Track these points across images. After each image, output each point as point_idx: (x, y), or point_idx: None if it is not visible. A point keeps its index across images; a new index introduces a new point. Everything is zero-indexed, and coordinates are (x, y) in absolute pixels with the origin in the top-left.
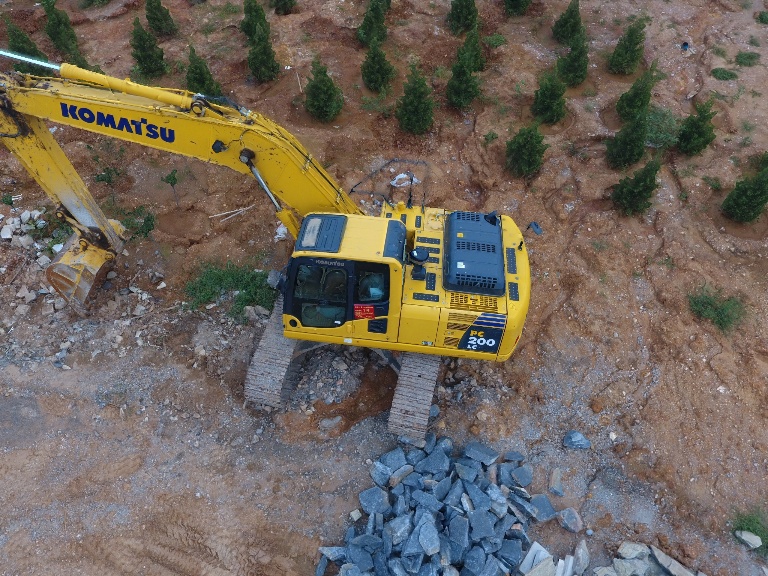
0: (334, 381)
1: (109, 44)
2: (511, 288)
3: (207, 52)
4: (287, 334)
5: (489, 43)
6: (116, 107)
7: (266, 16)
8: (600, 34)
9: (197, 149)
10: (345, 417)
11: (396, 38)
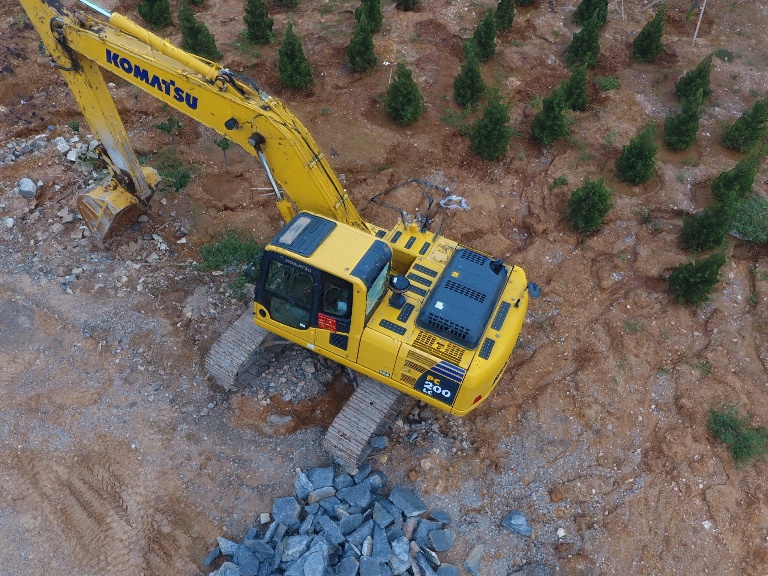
0: (297, 381)
1: (232, 4)
2: (486, 344)
3: (316, 31)
4: (257, 322)
5: (600, 84)
6: (151, 64)
7: (385, 8)
8: (728, 102)
9: (216, 121)
10: (297, 419)
11: (504, 58)
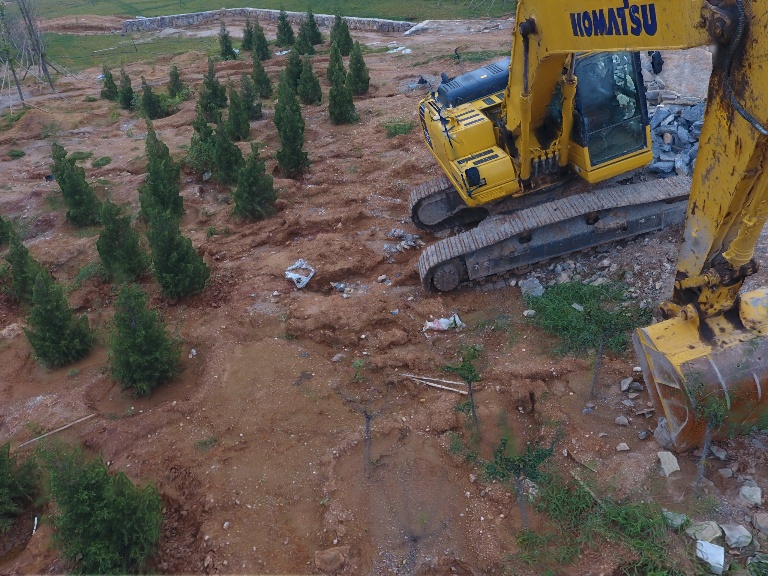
0: None
1: None
2: None
3: None
4: None
5: None
6: None
7: None
8: (6, 218)
9: None
10: None
11: None
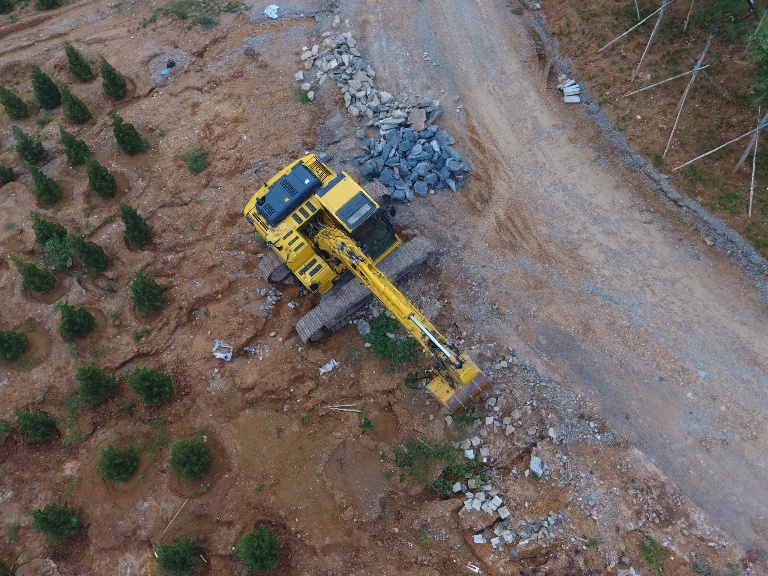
0: None
1: None
2: None
3: None
4: None
5: (6, 432)
6: None
7: None
8: None
9: None
10: None
11: None
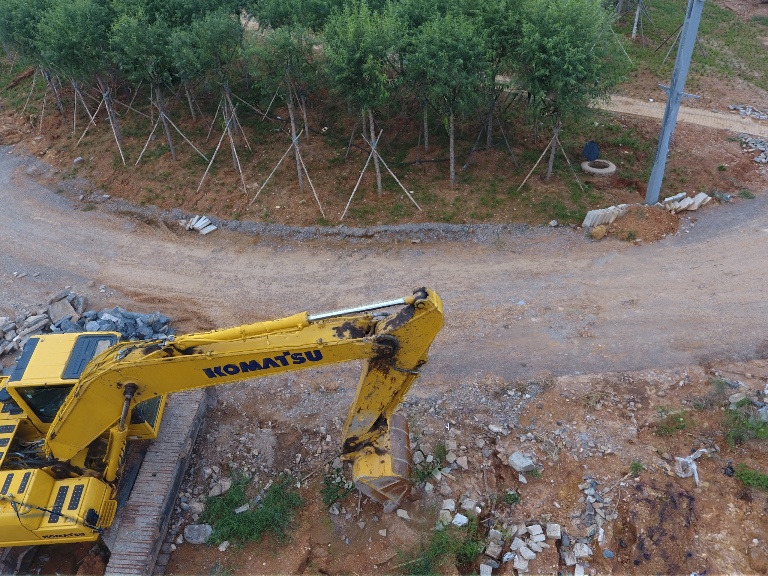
0: None
1: None
2: None
3: None
4: None
5: None
6: None
7: None
8: None
9: None
10: None
11: None
